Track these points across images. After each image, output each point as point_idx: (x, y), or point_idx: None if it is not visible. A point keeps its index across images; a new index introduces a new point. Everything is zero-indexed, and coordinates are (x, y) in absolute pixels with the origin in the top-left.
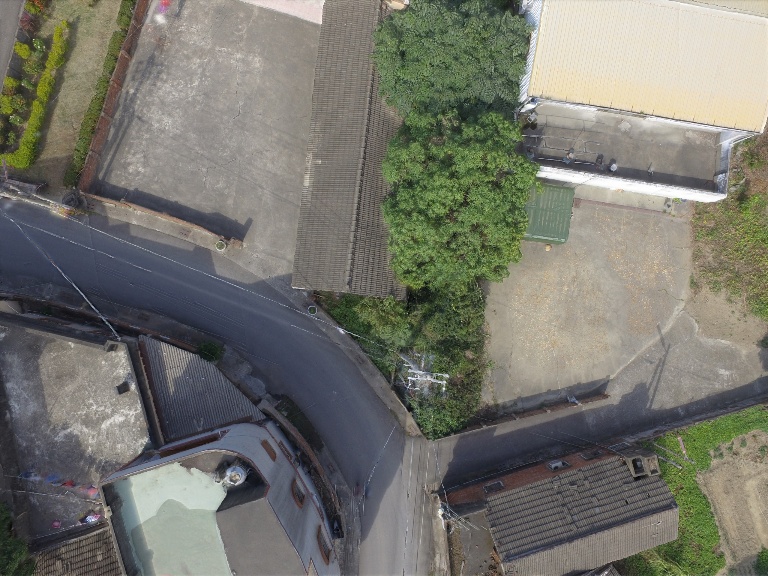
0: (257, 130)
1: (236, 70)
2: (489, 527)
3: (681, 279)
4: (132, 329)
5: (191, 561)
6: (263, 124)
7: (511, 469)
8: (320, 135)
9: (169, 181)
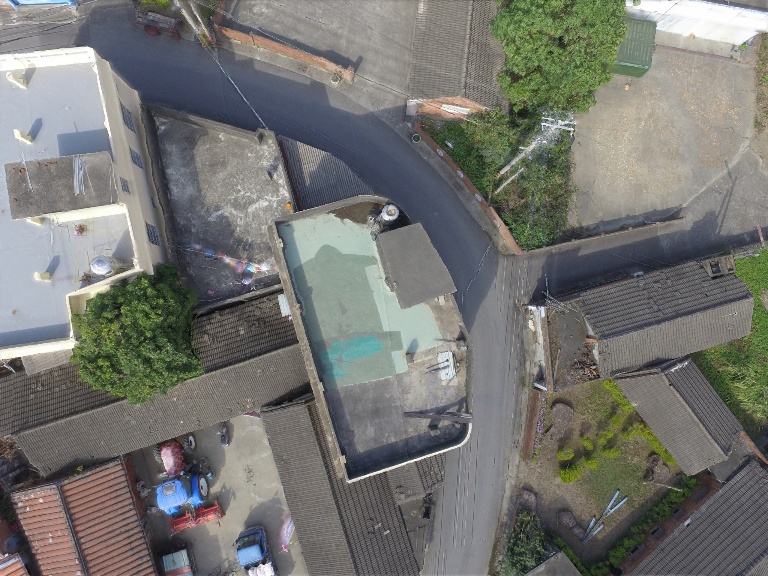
0: None
1: None
2: (583, 316)
3: (746, 119)
4: None
5: (344, 298)
6: None
7: (594, 286)
8: None
9: (289, 21)
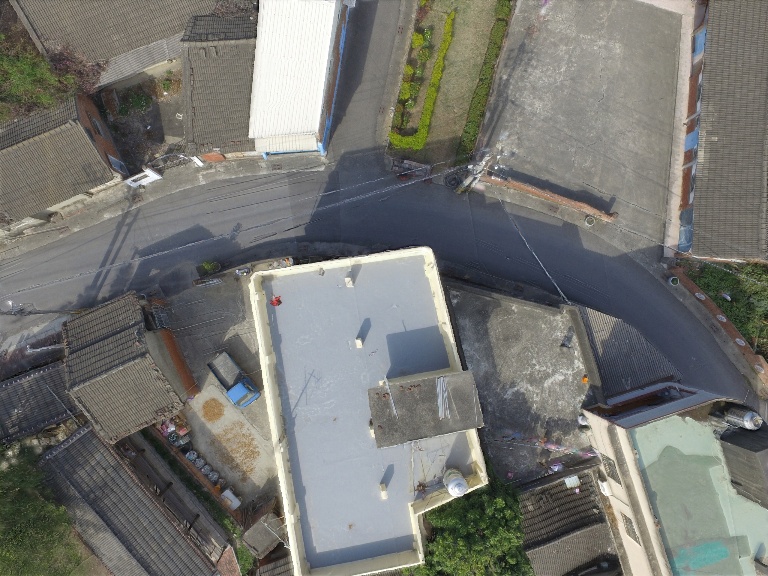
0: (619, 112)
1: (599, 56)
2: None
3: None
4: None
5: (689, 502)
6: (625, 106)
7: None
8: (715, 114)
9: (541, 161)
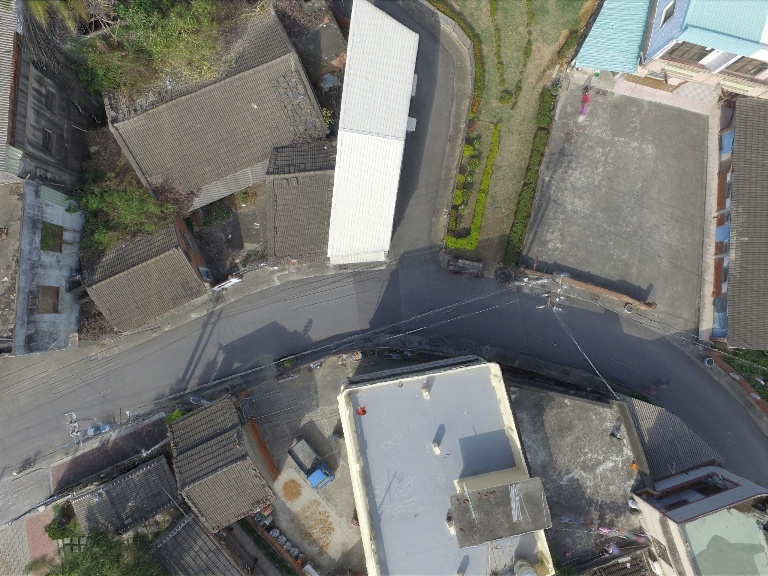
0: (654, 207)
1: (633, 157)
2: None
3: None
4: (573, 384)
5: None
6: (658, 202)
7: None
8: (744, 216)
9: (582, 254)
